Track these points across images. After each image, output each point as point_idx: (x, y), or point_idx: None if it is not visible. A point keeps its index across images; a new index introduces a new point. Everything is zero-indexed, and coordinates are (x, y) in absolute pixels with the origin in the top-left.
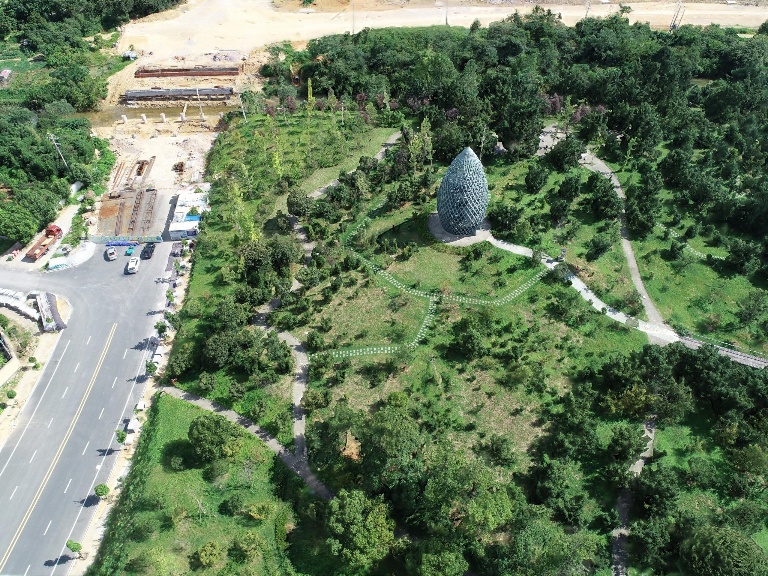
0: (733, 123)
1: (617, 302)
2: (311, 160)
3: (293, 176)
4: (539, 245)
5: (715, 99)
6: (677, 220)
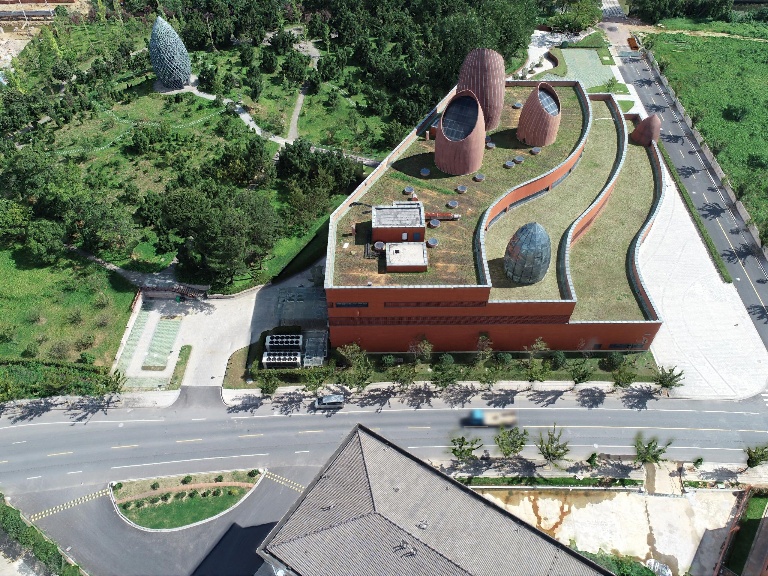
0: (426, 23)
1: (268, 127)
2: (92, 49)
3: (69, 57)
4: (228, 94)
5: (420, 7)
6: (346, 83)
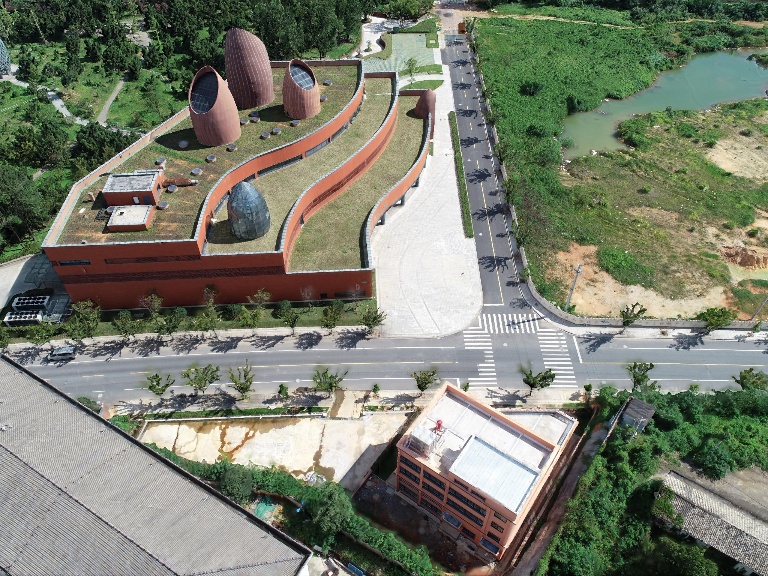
0: None
1: (78, 111)
2: None
3: None
4: (45, 82)
5: None
6: (168, 69)
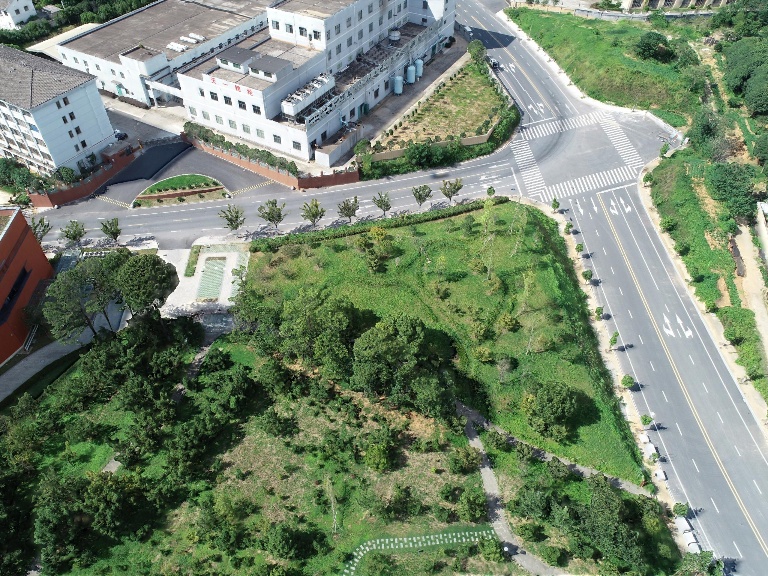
0: None
1: None
2: None
3: None
4: None
5: None
6: None
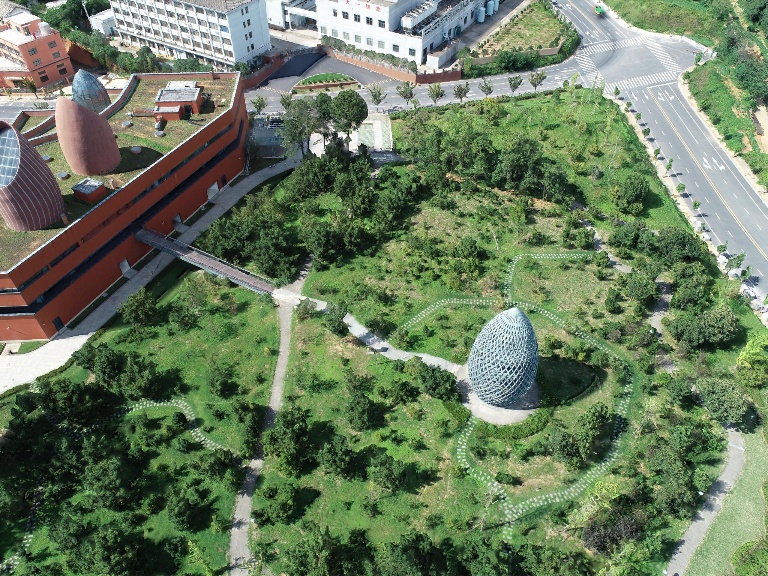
0: None
1: (320, 316)
2: None
3: None
4: None
5: None
6: None
